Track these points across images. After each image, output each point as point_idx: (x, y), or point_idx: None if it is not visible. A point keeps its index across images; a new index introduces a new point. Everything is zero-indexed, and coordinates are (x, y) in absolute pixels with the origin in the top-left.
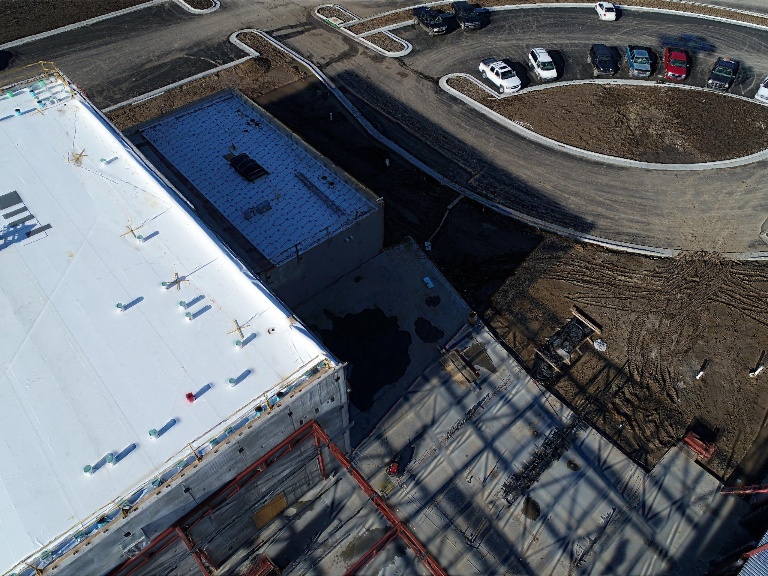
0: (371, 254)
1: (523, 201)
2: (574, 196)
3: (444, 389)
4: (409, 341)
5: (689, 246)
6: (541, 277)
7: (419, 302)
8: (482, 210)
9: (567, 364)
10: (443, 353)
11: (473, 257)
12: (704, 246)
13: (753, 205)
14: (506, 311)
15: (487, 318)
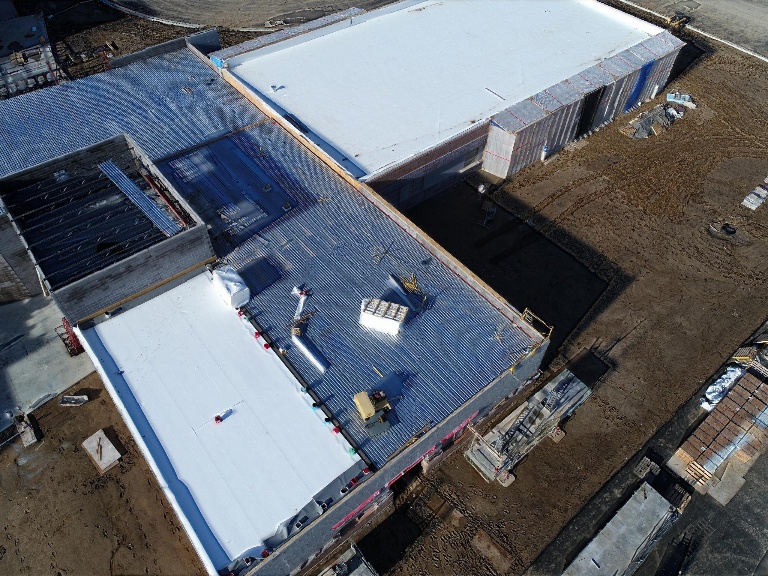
0: (8, 16)
1: (133, 3)
2: (168, 2)
3: (3, 65)
4: (0, 49)
5: (215, 24)
6: (105, 30)
7: (21, 36)
8: (101, 5)
9: (84, 61)
10: (13, 52)
11: (73, 22)
12: (224, 24)
13: (278, 10)
14: (70, 42)
15: (56, 44)
